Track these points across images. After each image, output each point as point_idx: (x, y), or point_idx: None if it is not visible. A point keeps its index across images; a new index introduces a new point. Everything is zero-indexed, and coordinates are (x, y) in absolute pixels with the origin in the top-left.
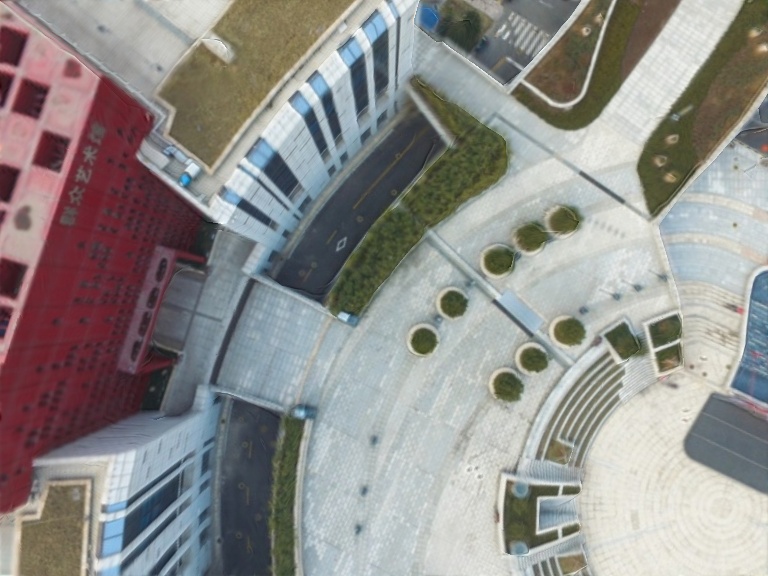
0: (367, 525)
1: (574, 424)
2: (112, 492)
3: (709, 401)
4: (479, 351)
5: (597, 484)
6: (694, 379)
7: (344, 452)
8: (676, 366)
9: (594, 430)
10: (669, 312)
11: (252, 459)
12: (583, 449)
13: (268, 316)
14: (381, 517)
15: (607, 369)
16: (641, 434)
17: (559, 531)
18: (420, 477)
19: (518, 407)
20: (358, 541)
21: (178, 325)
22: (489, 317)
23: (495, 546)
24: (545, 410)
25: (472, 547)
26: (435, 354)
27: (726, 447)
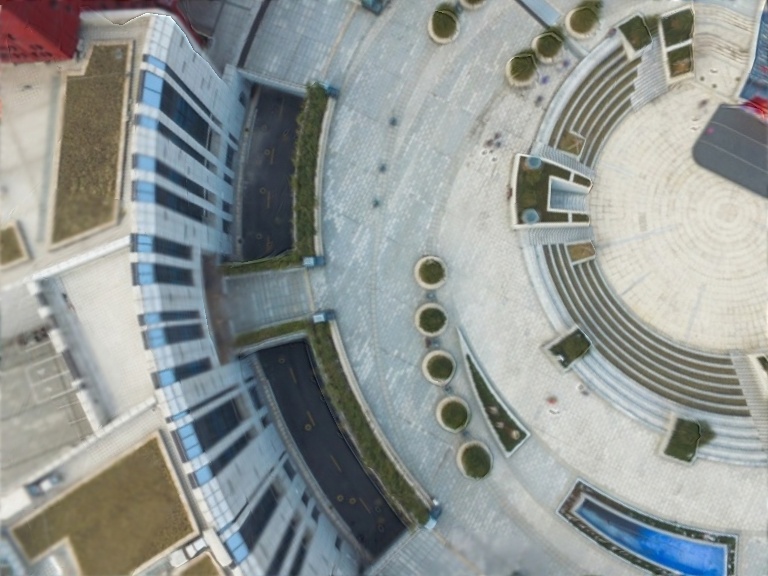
0: (384, 201)
1: (586, 121)
2: (153, 44)
3: (718, 111)
4: (497, 42)
5: (607, 187)
6: (704, 90)
7: (364, 133)
8: (687, 71)
9: (605, 133)
10: (682, 7)
11: (274, 163)
12: (594, 150)
13: (295, 5)
14: (398, 194)
15: (620, 67)
16: (651, 141)
17: (569, 215)
18: (437, 158)
19: (533, 95)
20: (375, 215)
21: (209, 13)
22: (507, 10)
23: (507, 222)
24: (559, 97)
25: (485, 224)
26: (454, 42)
27: (733, 153)
